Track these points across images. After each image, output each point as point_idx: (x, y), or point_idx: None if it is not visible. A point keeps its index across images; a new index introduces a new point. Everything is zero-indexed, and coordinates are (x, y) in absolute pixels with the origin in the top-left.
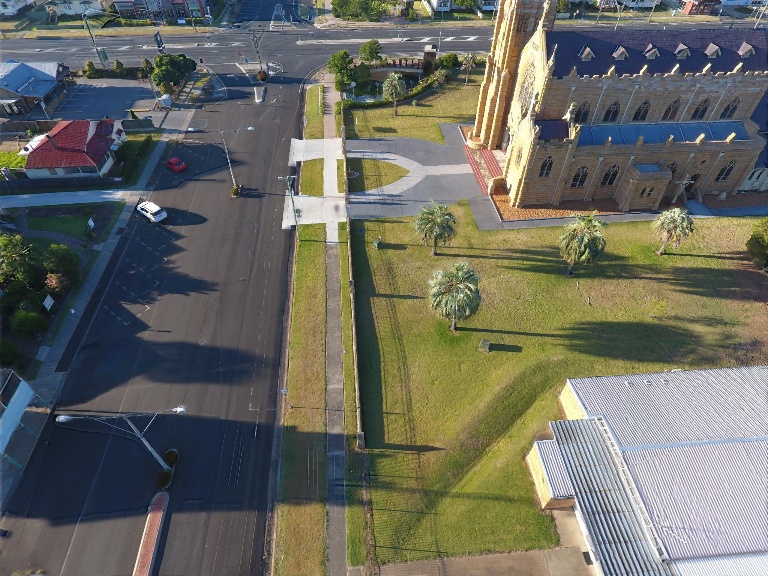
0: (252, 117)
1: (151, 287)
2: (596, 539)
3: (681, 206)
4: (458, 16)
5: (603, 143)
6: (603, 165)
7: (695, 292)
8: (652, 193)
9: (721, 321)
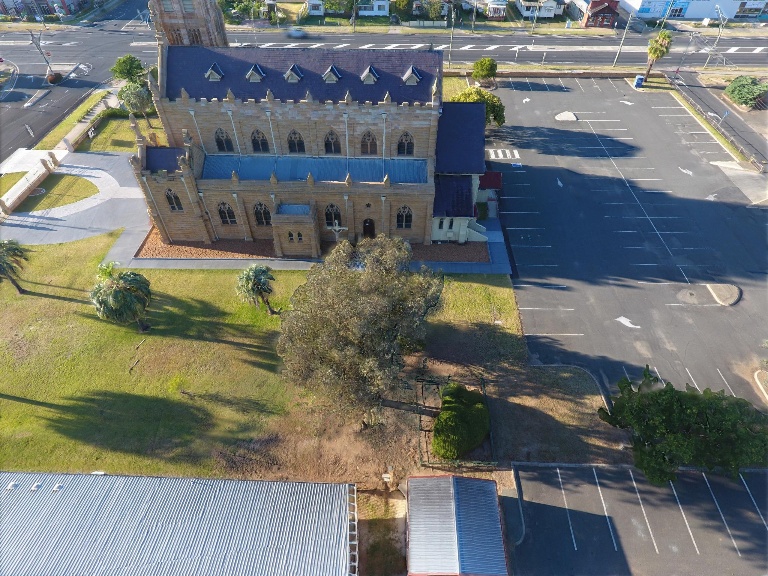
0: (2, 122)
1: None
2: None
3: None
4: (324, 21)
5: (248, 177)
6: (241, 202)
7: (266, 366)
8: (302, 238)
9: (261, 407)
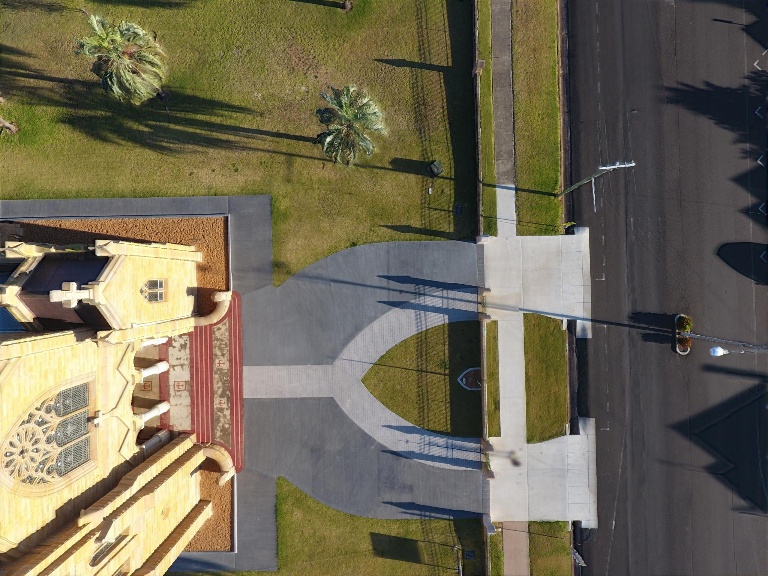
0: None
1: (764, 104)
2: None
3: None
4: None
5: None
6: None
7: (4, 50)
8: None
9: None
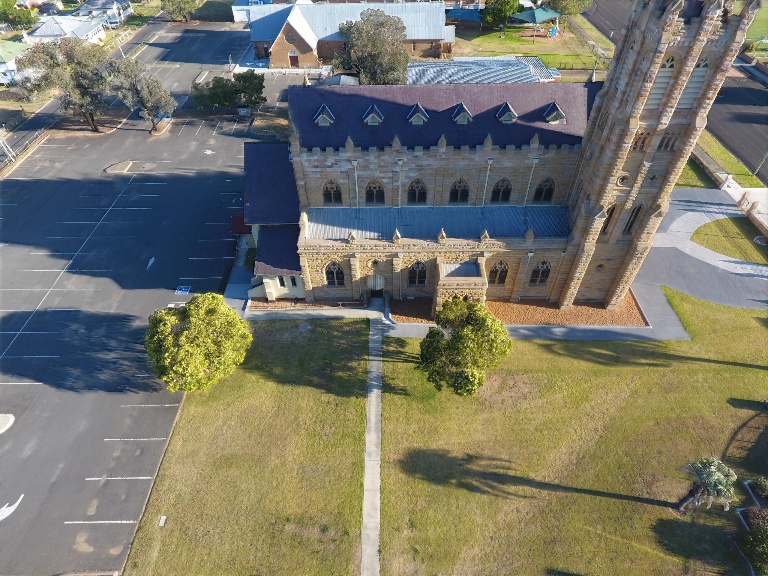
0: None
1: None
2: (541, 63)
3: None
4: None
5: None
6: None
7: None
8: None
9: None
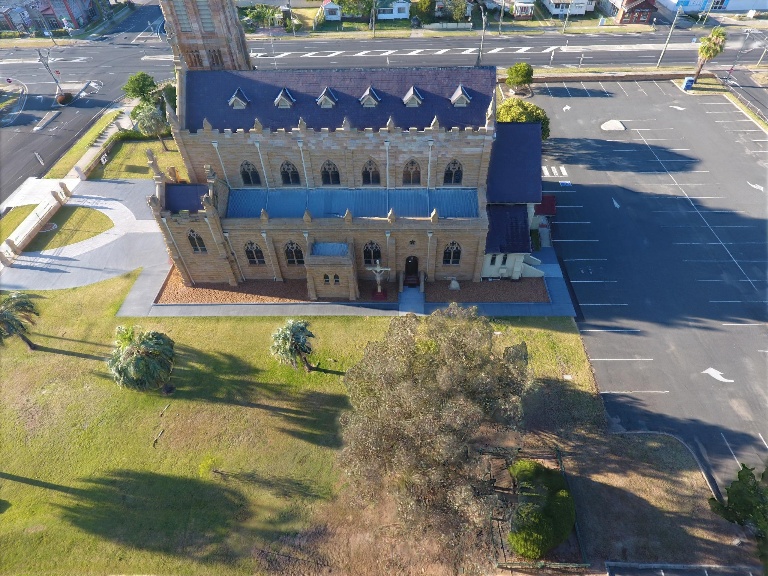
0: (11, 149)
1: None
2: None
3: (392, 296)
4: (342, 26)
5: (278, 213)
6: (270, 242)
7: (307, 436)
8: (339, 280)
9: (304, 489)
